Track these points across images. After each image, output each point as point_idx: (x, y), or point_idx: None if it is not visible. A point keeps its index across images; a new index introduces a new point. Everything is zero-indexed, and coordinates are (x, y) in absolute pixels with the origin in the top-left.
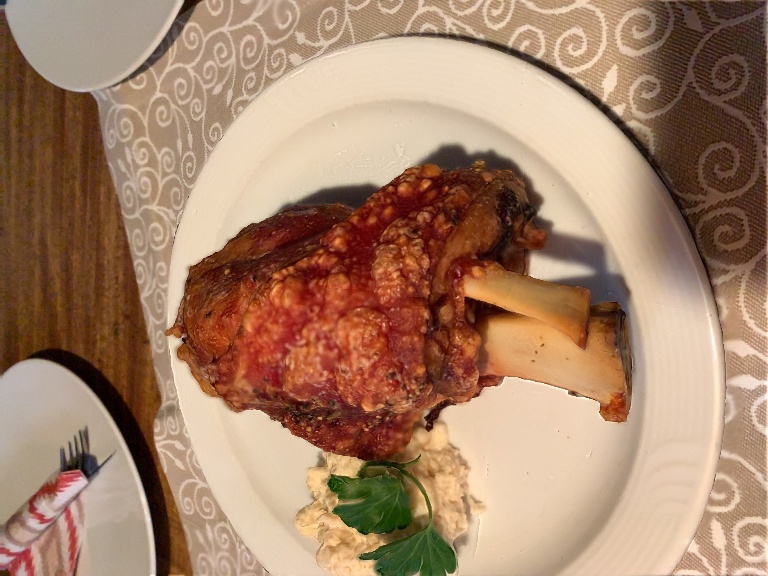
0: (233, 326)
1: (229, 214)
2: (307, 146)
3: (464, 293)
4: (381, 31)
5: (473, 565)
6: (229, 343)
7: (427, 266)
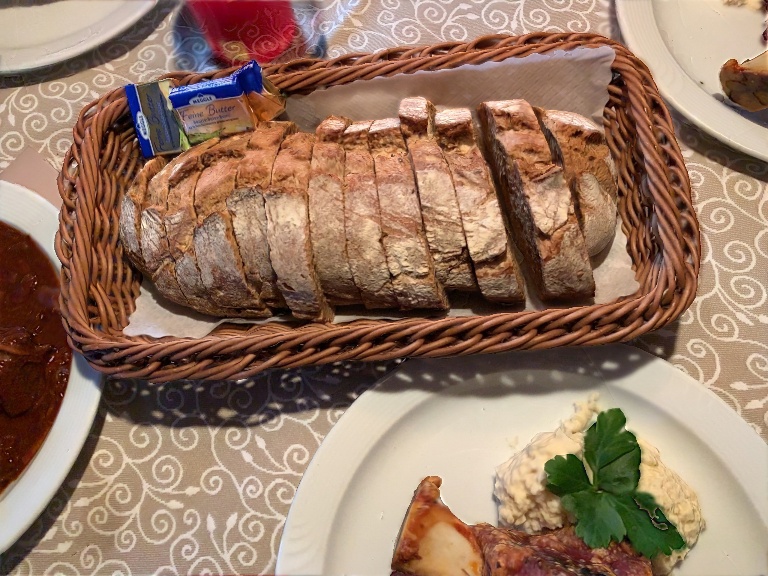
0: None
1: None
2: None
3: None
4: None
5: None
6: None
7: None
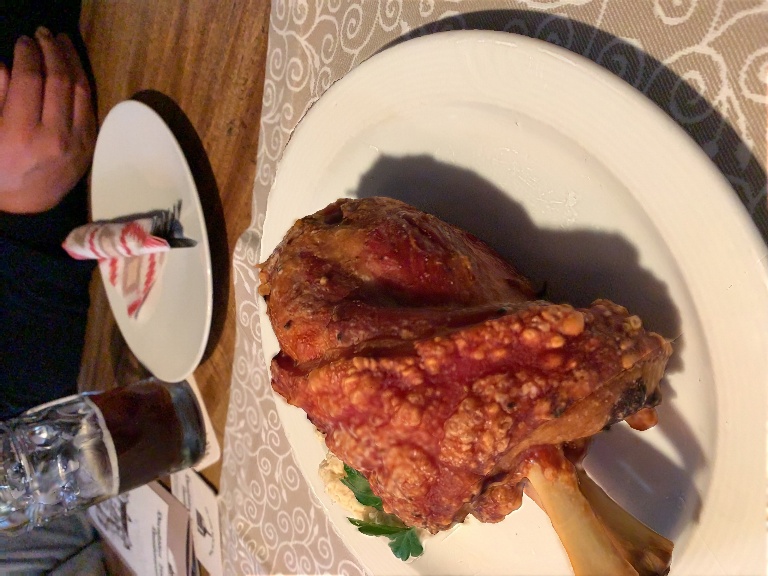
0: (305, 354)
1: (367, 129)
2: (478, 119)
3: (527, 475)
4: (638, 37)
5: (437, 546)
6: (297, 359)
7: (502, 451)
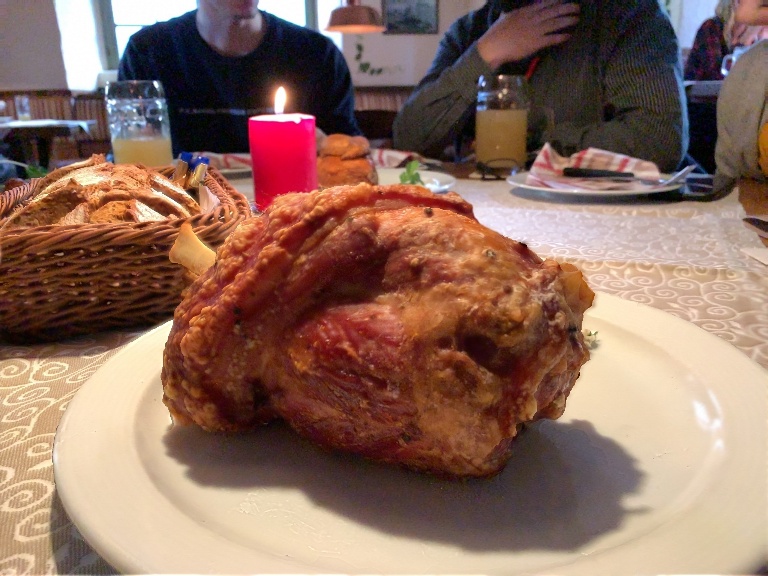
0: None
1: None
2: None
3: None
4: None
5: None
6: None
7: None
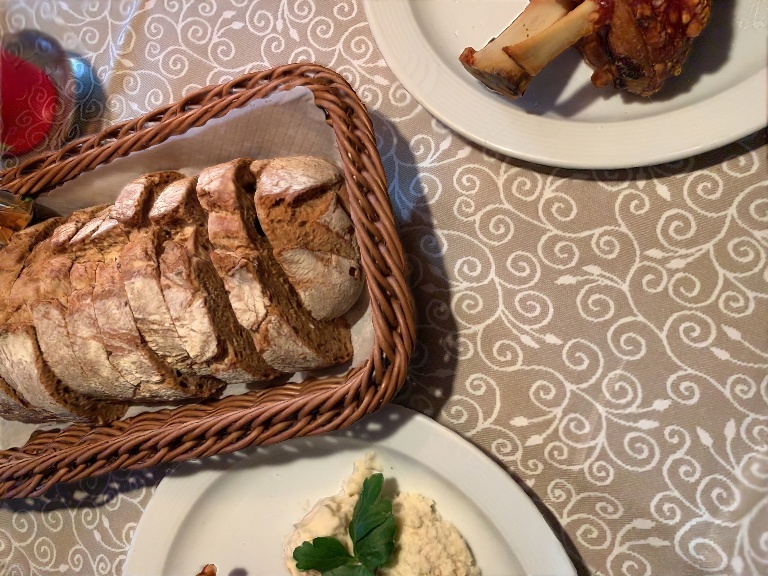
0: None
1: None
2: None
3: None
4: None
5: None
6: None
7: None
